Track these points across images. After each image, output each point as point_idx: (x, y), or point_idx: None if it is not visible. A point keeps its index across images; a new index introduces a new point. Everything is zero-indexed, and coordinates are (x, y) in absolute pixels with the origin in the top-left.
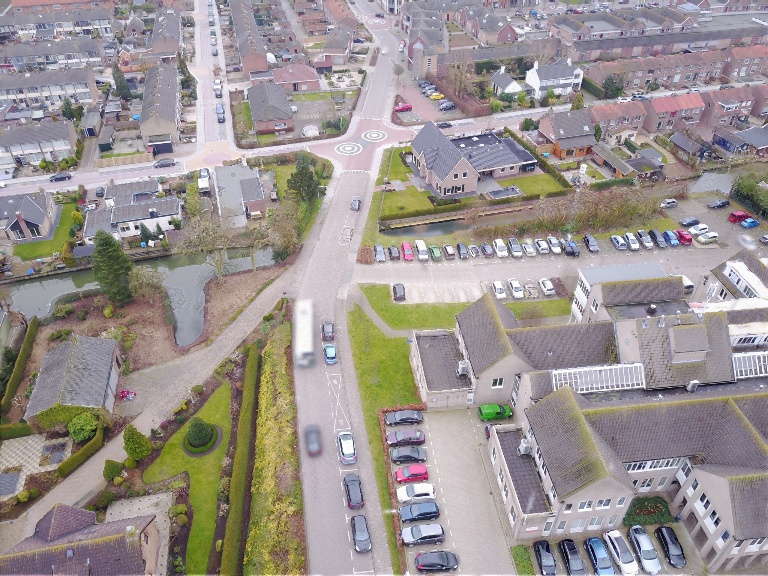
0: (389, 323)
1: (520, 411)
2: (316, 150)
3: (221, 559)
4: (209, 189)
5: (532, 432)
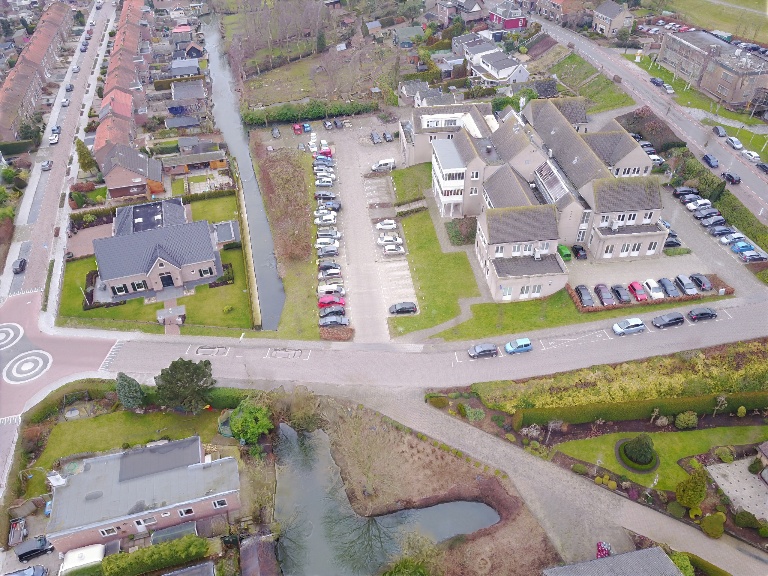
0: (452, 316)
1: (566, 235)
2: (7, 408)
3: (759, 400)
4: (115, 541)
5: (614, 212)
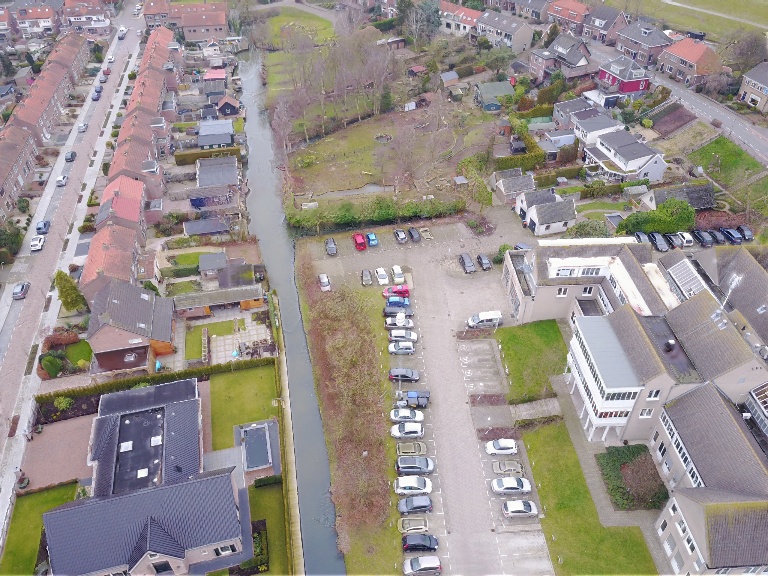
0: None
1: None
2: None
3: None
4: None
5: None
